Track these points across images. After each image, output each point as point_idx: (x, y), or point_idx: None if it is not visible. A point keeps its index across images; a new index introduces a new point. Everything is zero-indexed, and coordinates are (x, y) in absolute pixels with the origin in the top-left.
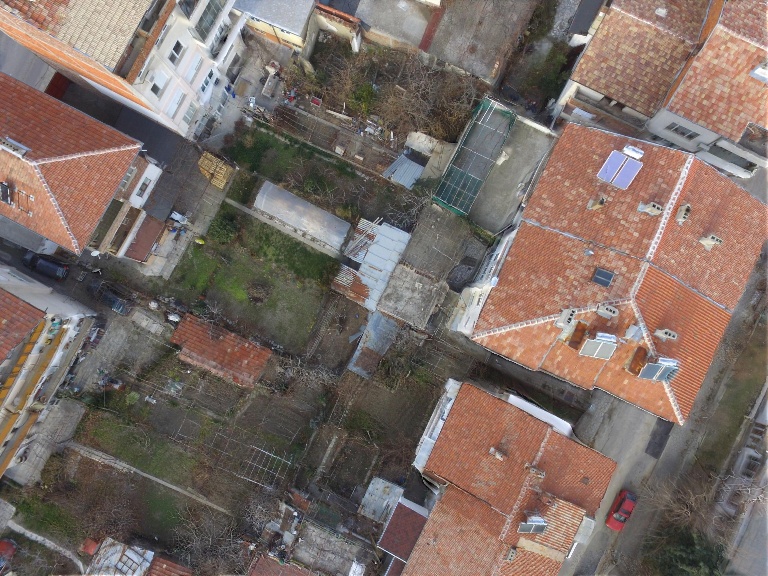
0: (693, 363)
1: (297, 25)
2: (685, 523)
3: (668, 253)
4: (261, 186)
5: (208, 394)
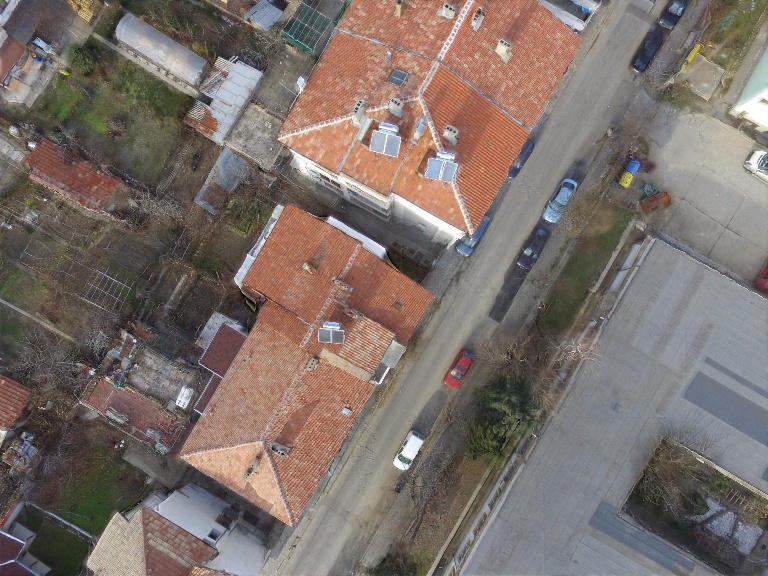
0: (486, 174)
1: None
2: (506, 370)
3: (461, 57)
4: (123, 17)
5: (63, 223)
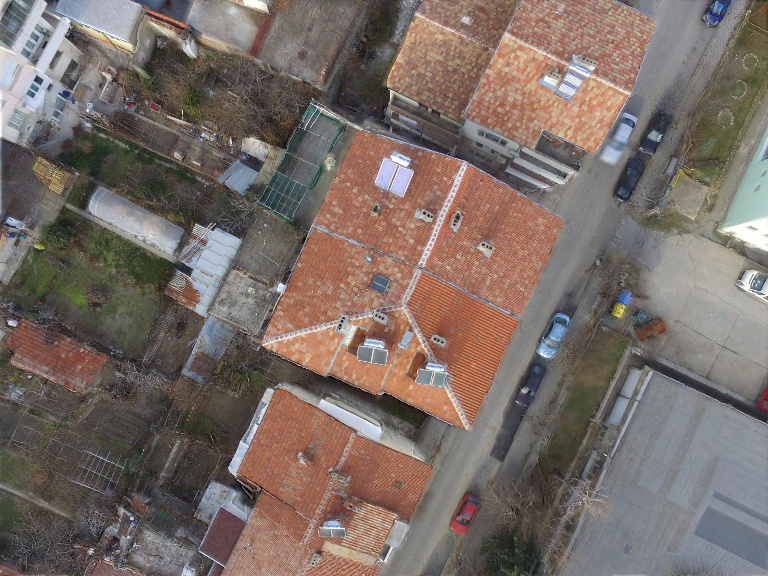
0: (477, 368)
1: (124, 32)
2: (512, 526)
3: (442, 260)
4: (95, 192)
5: (50, 399)
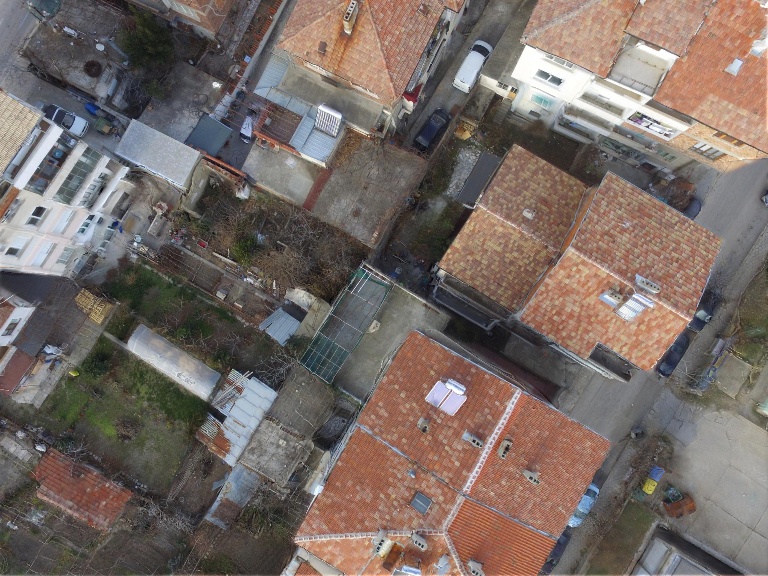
0: None
1: (180, 177)
2: None
3: (487, 486)
4: (135, 329)
5: (70, 525)
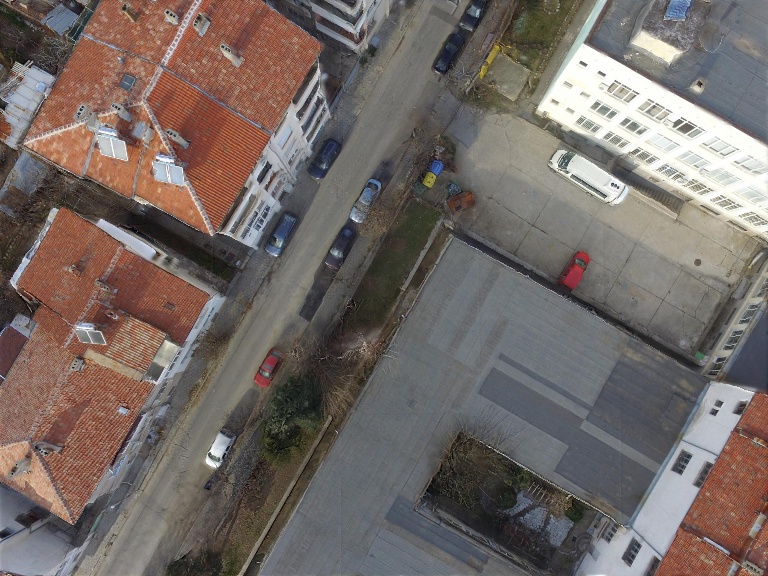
0: (225, 177)
1: None
2: None
3: (186, 61)
4: None
5: None
